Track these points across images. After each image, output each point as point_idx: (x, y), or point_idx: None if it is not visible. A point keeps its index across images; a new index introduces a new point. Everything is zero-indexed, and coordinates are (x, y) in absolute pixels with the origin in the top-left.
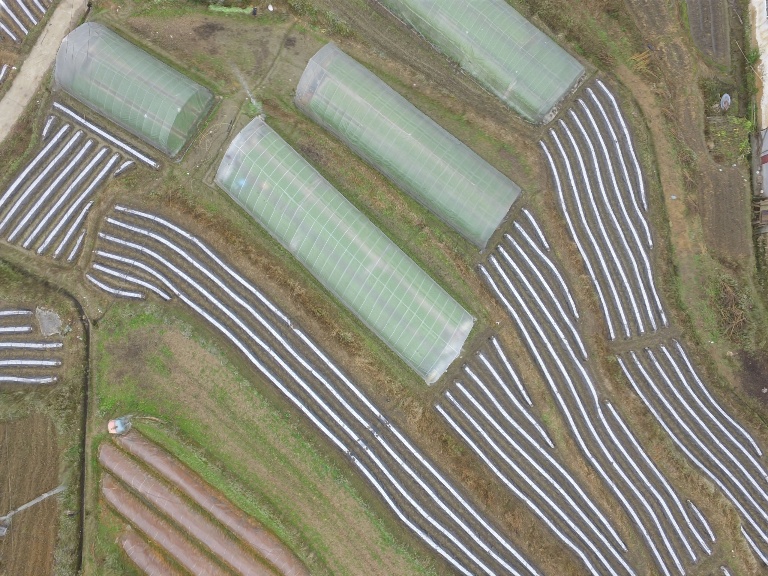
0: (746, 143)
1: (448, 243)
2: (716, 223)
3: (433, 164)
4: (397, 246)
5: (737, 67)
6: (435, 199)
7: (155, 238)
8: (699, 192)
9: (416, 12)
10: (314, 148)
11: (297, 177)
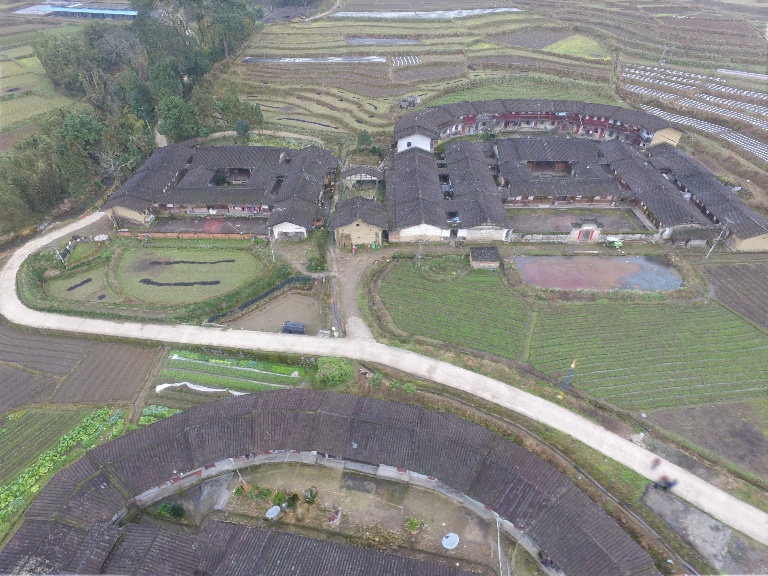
0: None
1: None
2: None
3: None
4: None
5: None
6: None
7: None
8: None
9: None
10: None
11: None
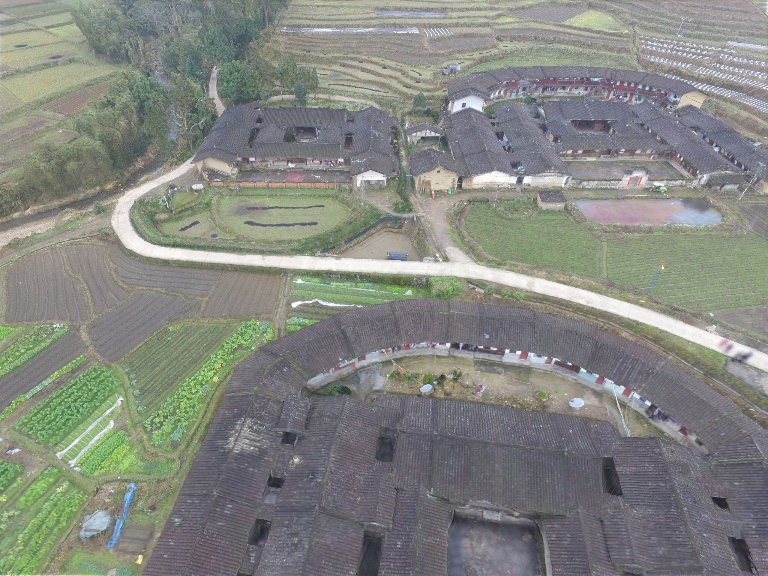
0: None
1: None
2: None
3: None
4: None
5: None
6: None
7: None
8: None
9: None
10: None
11: None
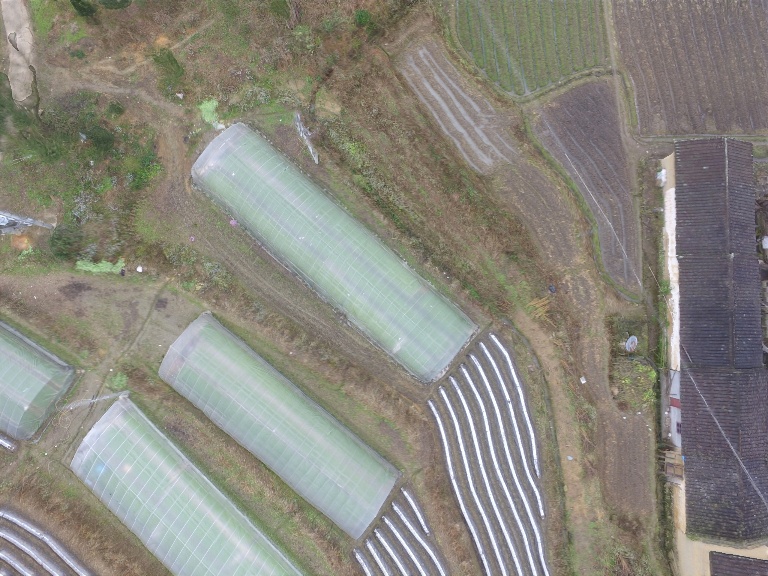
0: (650, 393)
1: (321, 528)
2: (618, 476)
3: (298, 462)
4: (264, 537)
5: (649, 294)
6: (302, 494)
7: (3, 537)
8: (601, 442)
9: (298, 267)
10: (180, 426)
11: (153, 476)
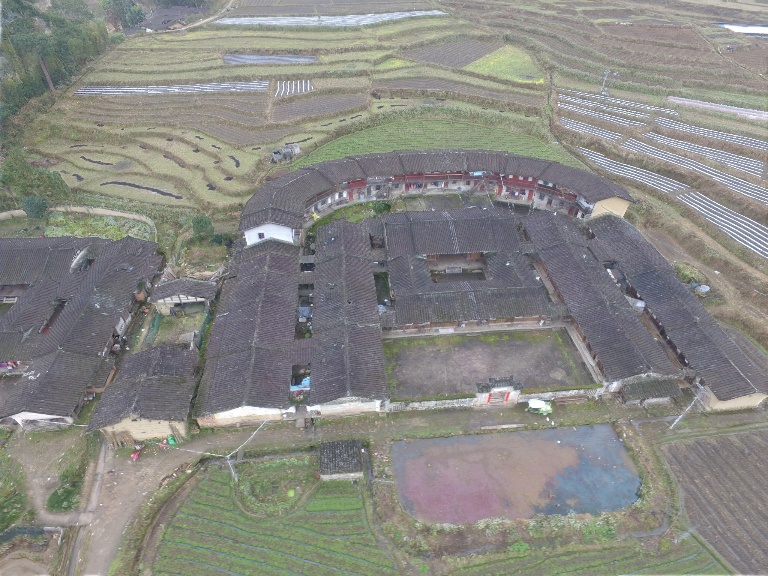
0: None
1: None
2: None
3: None
4: None
5: None
6: None
7: None
8: None
9: None
10: None
11: None
